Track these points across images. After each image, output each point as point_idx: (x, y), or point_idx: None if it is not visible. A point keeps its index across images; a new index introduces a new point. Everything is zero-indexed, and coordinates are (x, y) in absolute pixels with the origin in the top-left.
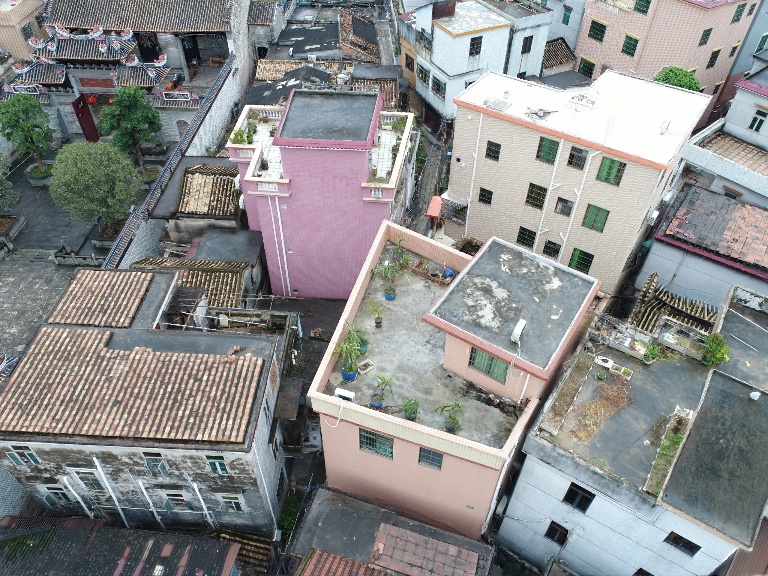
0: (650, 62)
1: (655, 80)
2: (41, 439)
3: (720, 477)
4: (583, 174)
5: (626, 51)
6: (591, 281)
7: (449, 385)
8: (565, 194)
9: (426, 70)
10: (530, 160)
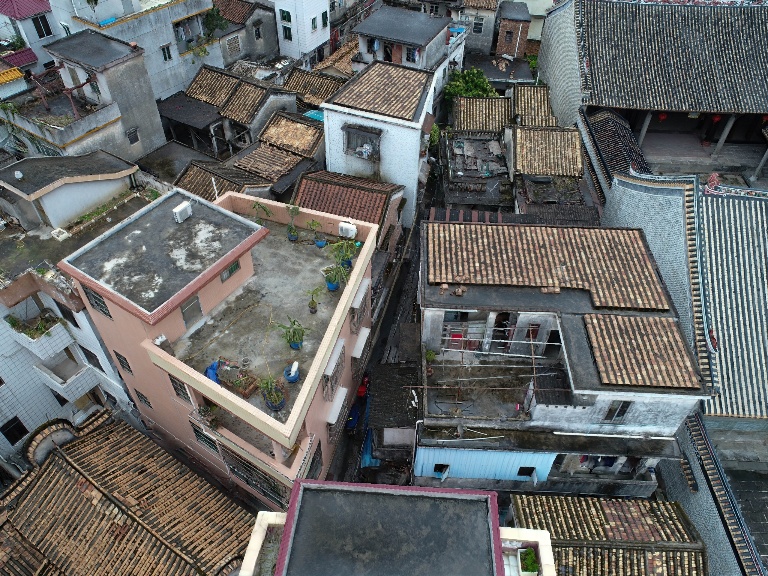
0: None
1: None
2: (584, 226)
3: (87, 167)
4: None
5: None
6: None
7: (254, 259)
8: None
9: None
10: None
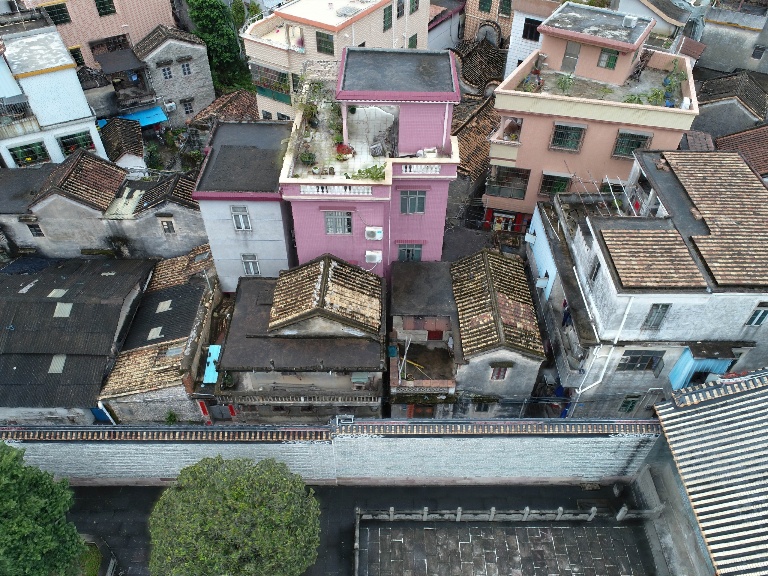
0: (135, 7)
1: (196, 1)
2: None
3: (666, 8)
4: (405, 17)
5: (105, 12)
6: (567, 5)
7: (635, 84)
8: (399, 44)
9: (39, 143)
10: (381, 36)
